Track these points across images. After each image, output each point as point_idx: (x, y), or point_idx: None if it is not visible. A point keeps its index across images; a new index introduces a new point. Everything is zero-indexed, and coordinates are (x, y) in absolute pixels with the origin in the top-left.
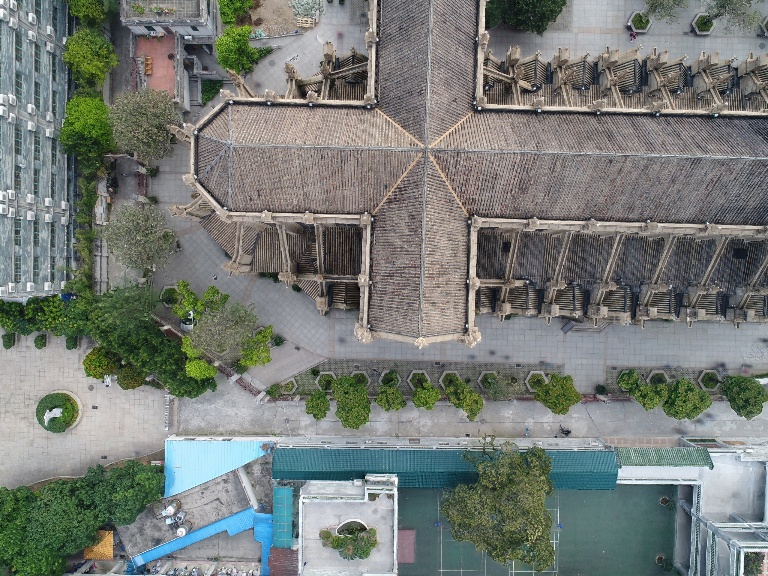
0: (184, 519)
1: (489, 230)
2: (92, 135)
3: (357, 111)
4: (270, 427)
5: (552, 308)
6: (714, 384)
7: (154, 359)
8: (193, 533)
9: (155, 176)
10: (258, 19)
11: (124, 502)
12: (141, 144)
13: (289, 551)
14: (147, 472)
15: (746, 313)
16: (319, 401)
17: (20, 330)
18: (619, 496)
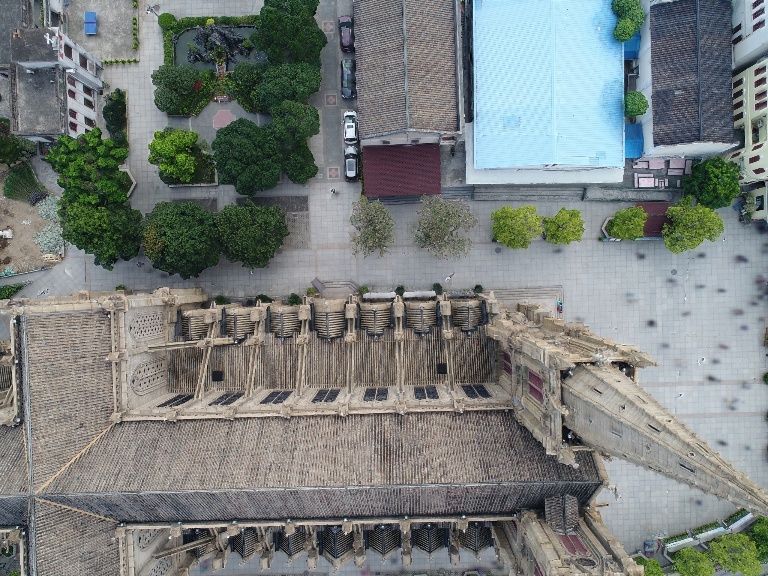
0: None
1: None
2: None
3: (3, 429)
4: None
5: (260, 561)
6: None
7: None
8: None
9: None
10: (6, 258)
11: None
12: None
13: None
14: None
15: (450, 556)
16: None
17: None
18: None
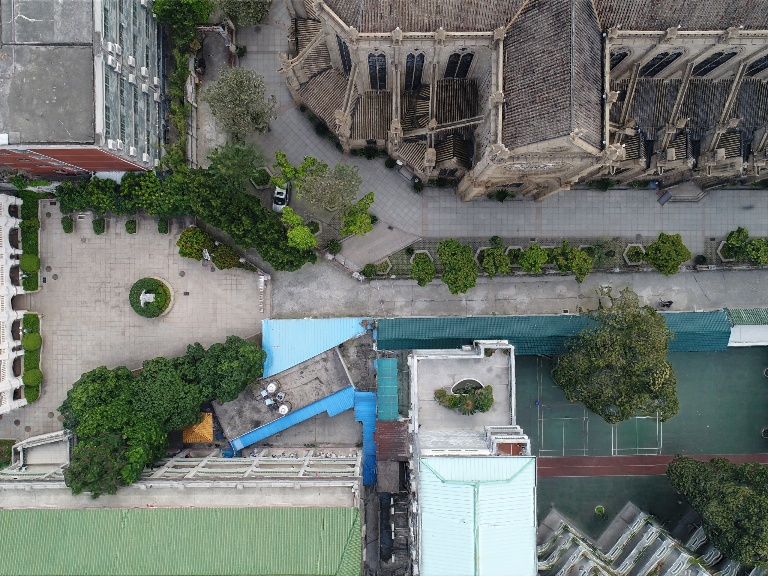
0: (284, 399)
1: None
2: (188, 1)
3: None
4: (365, 309)
5: (668, 152)
6: None
7: (256, 228)
8: (293, 414)
9: (243, 56)
10: None
11: (230, 373)
12: (241, 4)
13: (396, 423)
14: (250, 346)
15: None
16: (425, 265)
17: (115, 208)
18: (722, 369)
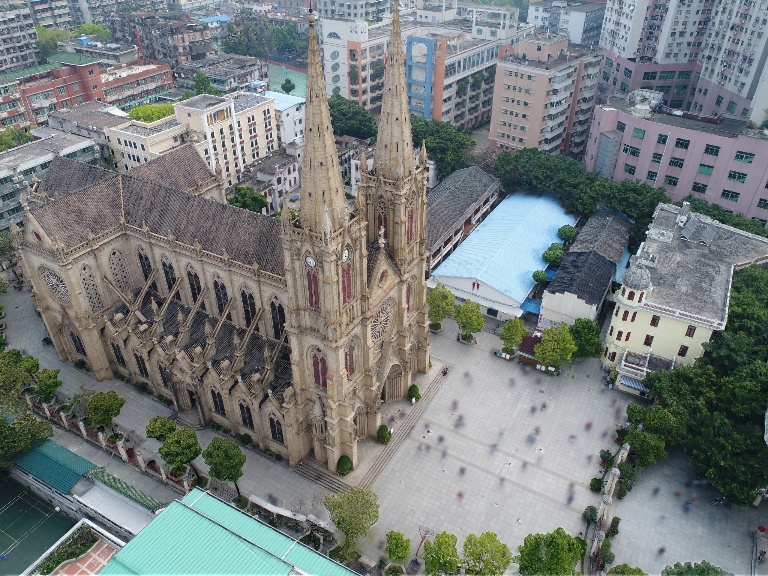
0: None
1: (155, 292)
2: None
3: None
4: None
5: None
6: (240, 506)
7: None
8: None
9: None
10: None
11: None
12: None
13: None
14: None
15: None
16: None
17: None
18: None
